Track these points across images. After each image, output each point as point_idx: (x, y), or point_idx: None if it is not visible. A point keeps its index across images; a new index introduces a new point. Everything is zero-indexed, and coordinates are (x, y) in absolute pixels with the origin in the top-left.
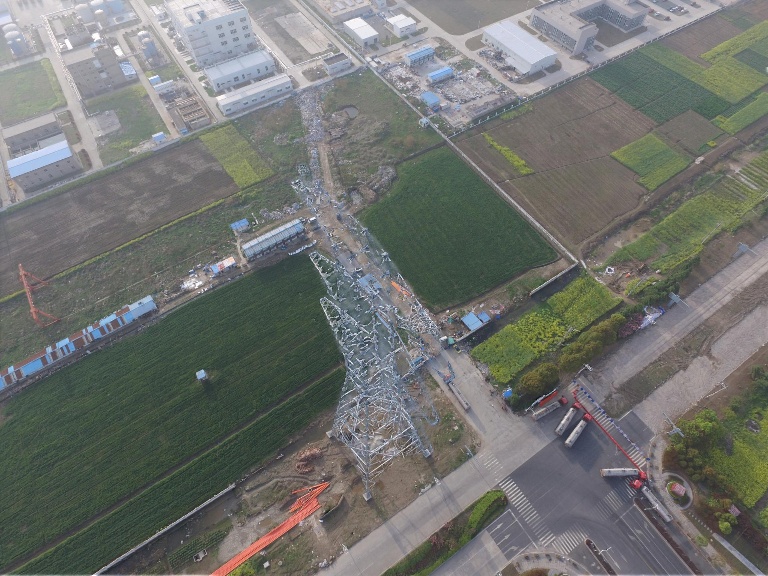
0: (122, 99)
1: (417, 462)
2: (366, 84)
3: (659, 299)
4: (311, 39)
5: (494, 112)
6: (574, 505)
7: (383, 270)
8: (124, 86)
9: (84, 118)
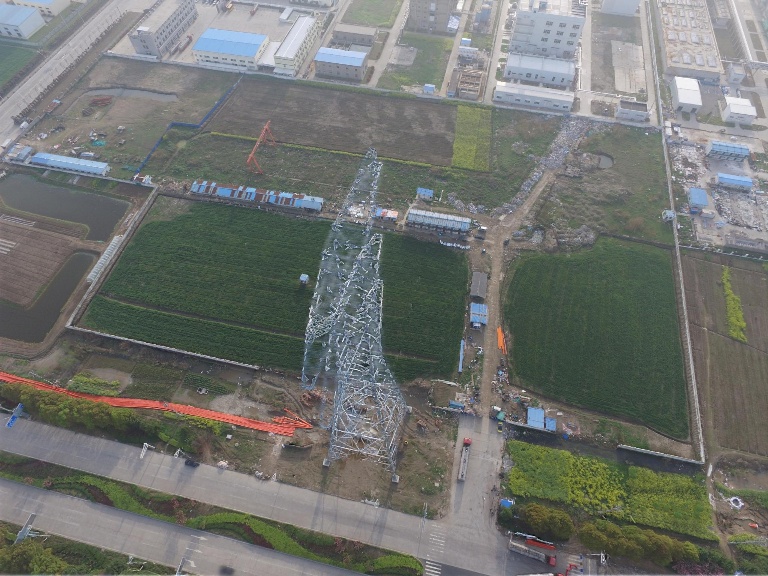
0: (430, 44)
1: (383, 477)
2: (644, 145)
3: None
4: (629, 76)
5: (760, 254)
6: None
7: (502, 312)
8: (441, 35)
9: (394, 44)
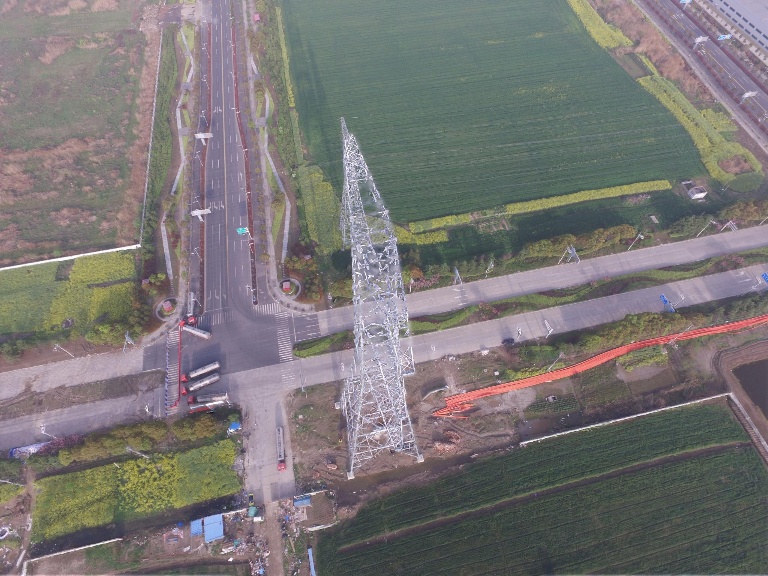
0: None
1: None
2: None
3: (2, 461)
4: None
5: None
6: (247, 327)
7: None
8: None
9: None
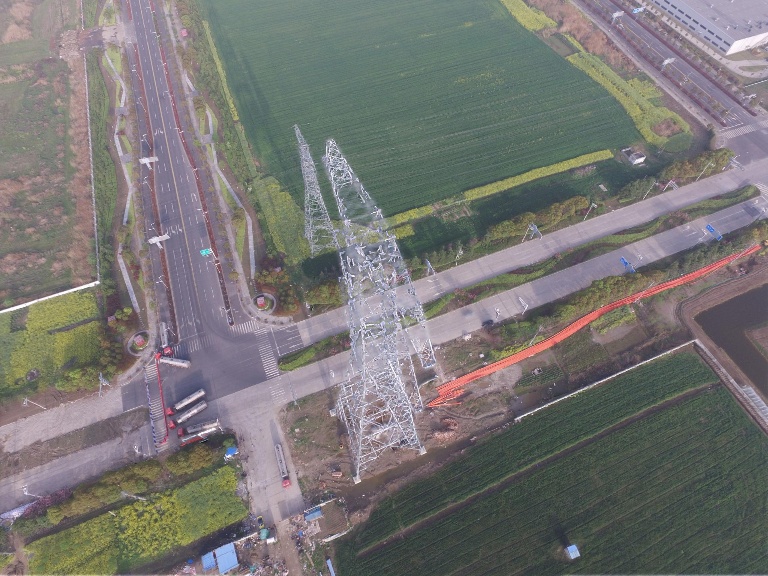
0: None
1: None
2: None
3: None
4: None
5: None
6: (227, 349)
7: None
8: None
9: None
